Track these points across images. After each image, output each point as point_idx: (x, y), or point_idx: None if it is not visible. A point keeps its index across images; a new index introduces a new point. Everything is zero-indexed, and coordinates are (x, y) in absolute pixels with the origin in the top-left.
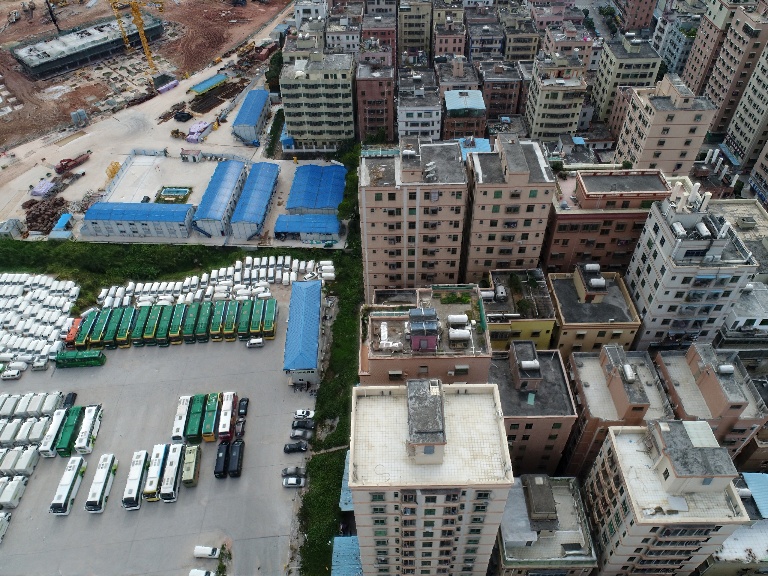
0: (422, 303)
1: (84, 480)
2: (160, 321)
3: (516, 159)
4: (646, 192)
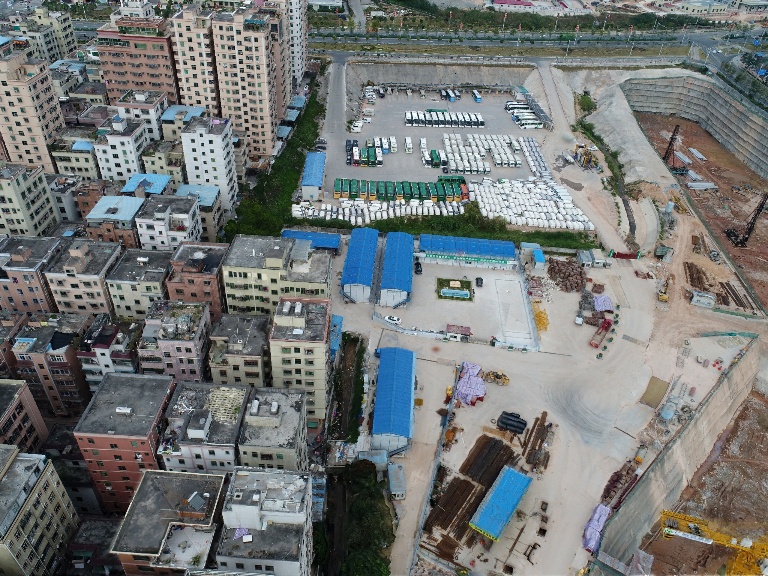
0: (257, 6)
1: (419, 150)
2: (410, 187)
3: (193, 6)
4: (135, 17)
